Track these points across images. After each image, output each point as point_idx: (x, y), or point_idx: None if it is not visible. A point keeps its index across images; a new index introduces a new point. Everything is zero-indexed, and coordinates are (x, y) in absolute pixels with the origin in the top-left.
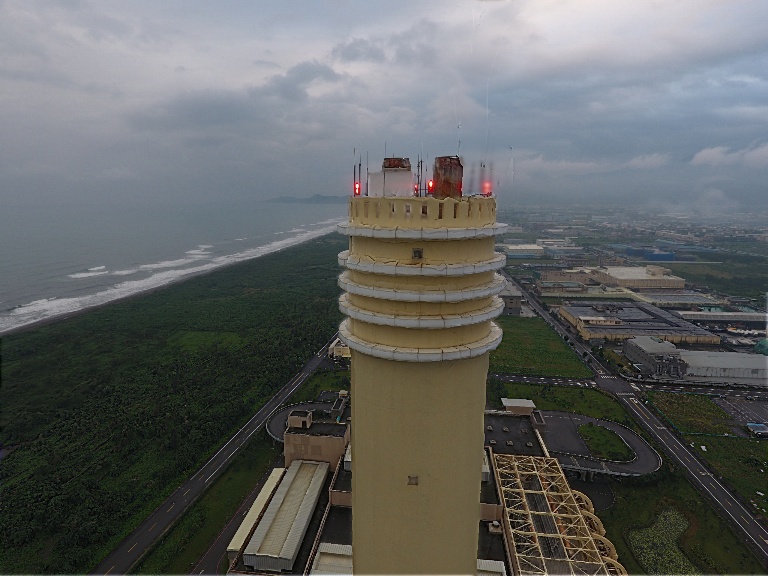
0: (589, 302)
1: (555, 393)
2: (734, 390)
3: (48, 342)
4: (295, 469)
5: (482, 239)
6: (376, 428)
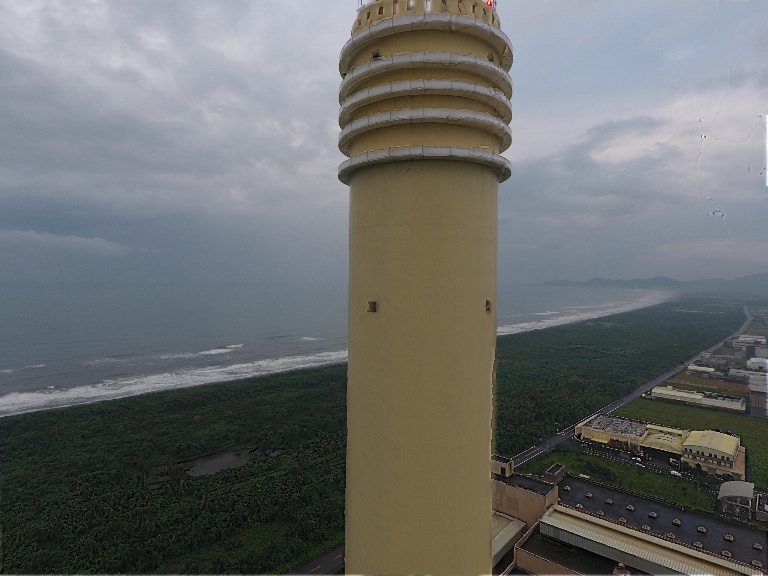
0: None
1: None
2: None
3: (326, 379)
4: None
5: (443, 30)
6: (350, 255)
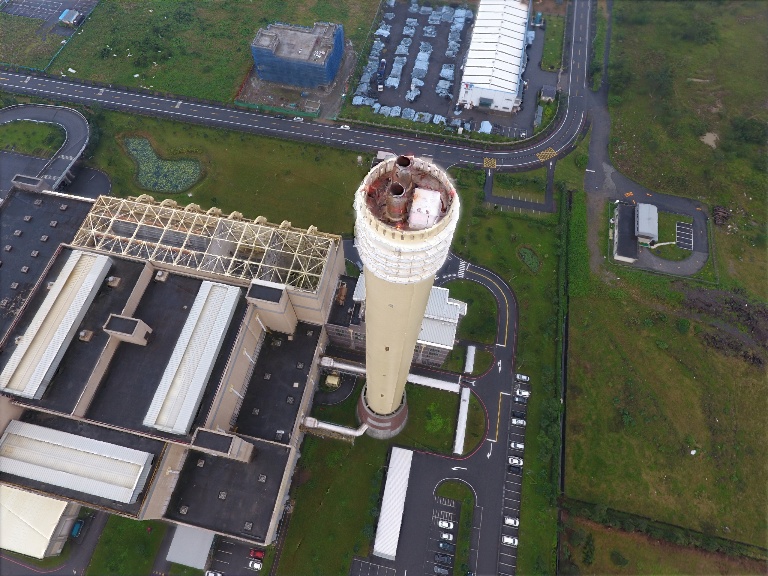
0: None
1: None
2: None
3: None
4: (8, 462)
5: None
6: None
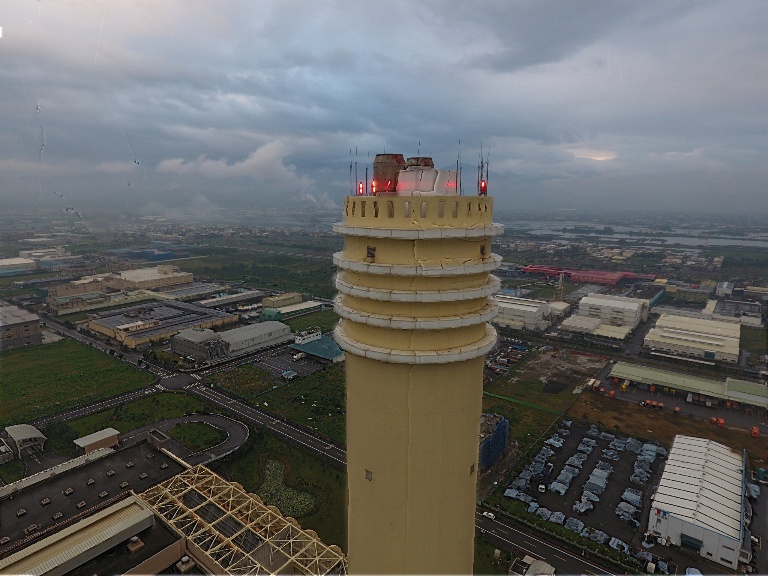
0: (118, 310)
1: (129, 410)
2: (263, 353)
3: None
4: None
5: None
6: (446, 438)
